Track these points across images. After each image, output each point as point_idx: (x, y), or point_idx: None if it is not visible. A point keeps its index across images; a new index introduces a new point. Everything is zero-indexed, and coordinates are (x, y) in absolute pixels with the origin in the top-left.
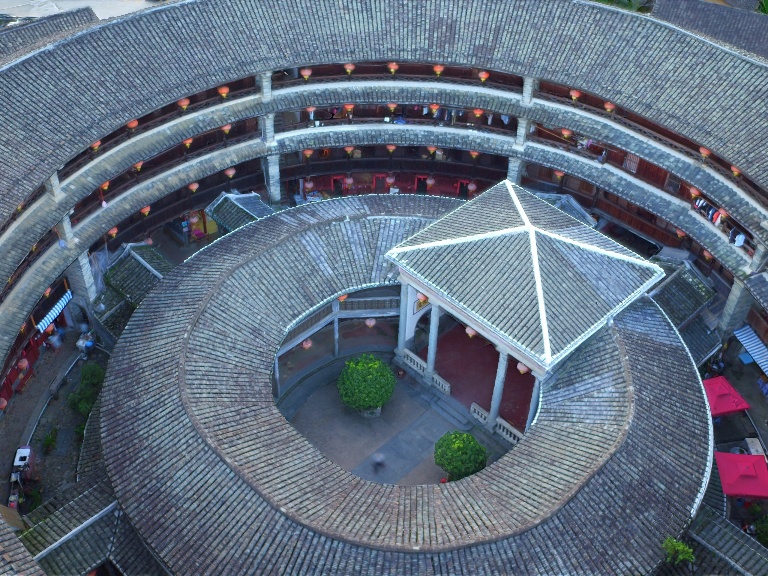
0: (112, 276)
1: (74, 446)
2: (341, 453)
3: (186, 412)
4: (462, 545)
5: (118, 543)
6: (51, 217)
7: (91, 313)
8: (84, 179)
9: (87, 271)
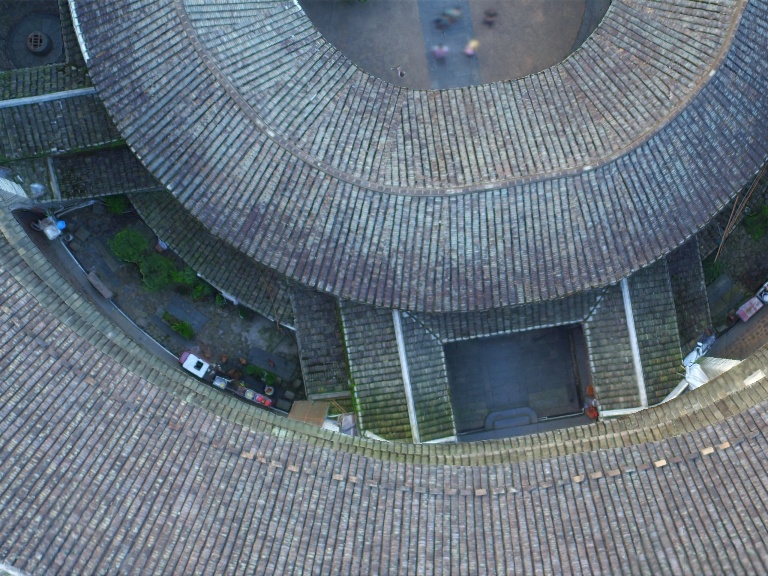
0: (2, 152)
1: (201, 305)
2: (398, 43)
3: (391, 194)
4: (737, 29)
5: (437, 328)
6: None
7: (35, 204)
8: None
9: (1, 183)
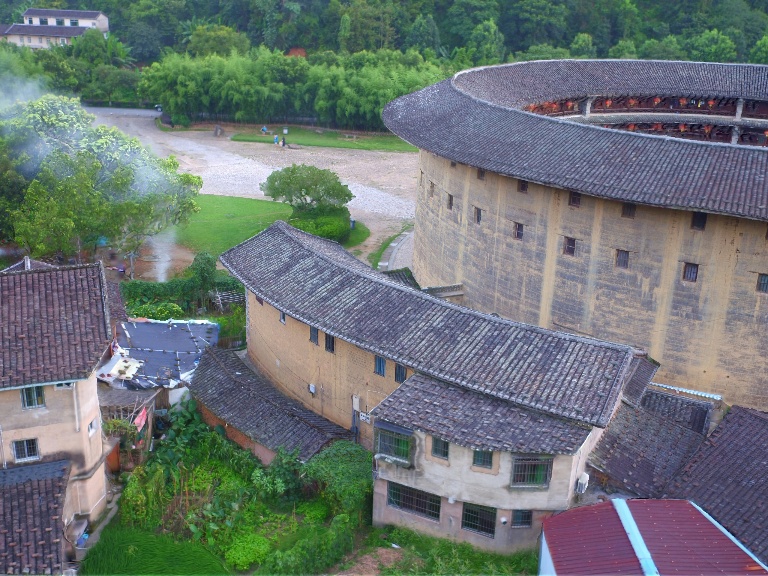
0: None
1: None
2: None
3: None
4: None
5: None
6: (723, 122)
7: None
8: (757, 122)
9: None
